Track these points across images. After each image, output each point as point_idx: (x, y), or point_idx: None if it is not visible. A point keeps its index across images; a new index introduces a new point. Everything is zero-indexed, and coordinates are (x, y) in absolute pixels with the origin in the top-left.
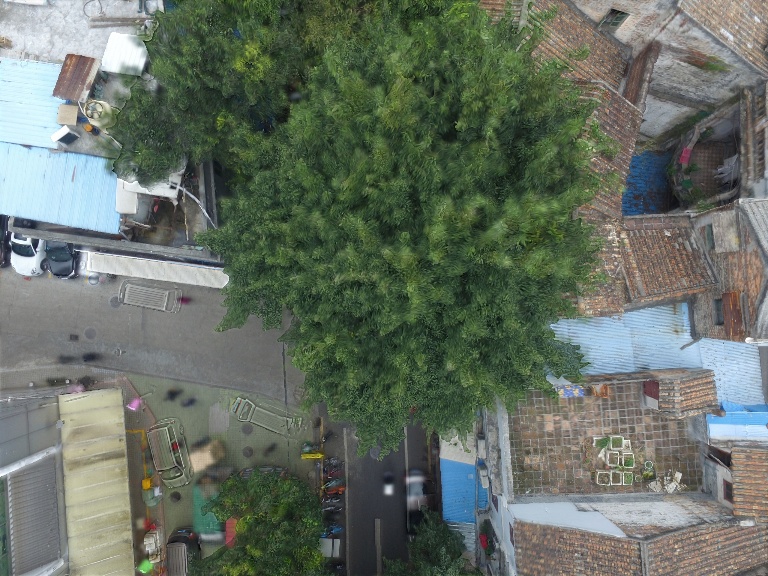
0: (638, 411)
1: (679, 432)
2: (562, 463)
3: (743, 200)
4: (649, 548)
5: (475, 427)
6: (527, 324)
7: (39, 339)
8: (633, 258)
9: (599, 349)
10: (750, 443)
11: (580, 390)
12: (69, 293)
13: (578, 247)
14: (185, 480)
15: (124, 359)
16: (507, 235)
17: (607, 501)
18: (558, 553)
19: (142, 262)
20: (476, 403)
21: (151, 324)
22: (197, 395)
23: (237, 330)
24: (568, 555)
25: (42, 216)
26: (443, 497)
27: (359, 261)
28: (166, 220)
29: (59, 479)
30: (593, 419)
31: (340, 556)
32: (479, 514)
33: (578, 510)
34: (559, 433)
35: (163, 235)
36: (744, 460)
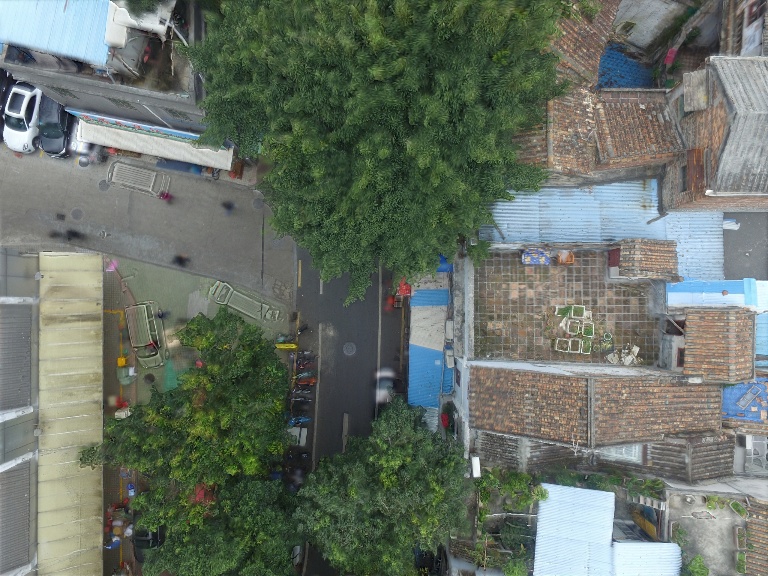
0: (602, 285)
1: (640, 308)
2: (524, 330)
3: (714, 58)
4: (596, 386)
5: (446, 314)
6: (487, 116)
7: (26, 216)
8: (606, 125)
9: (568, 220)
10: (705, 307)
11: (546, 258)
12: (59, 173)
13: (540, 36)
14: (160, 360)
15: (108, 242)
16: (470, 3)
17: (564, 364)
18: (510, 395)
19: (131, 134)
20: (437, 220)
21: (137, 209)
22: (178, 282)
23: (222, 221)
24: (519, 396)
25: (32, 44)
26: (410, 382)
27: (327, 30)
28: (155, 71)
29: (34, 331)
30: (557, 289)
31: (307, 447)
32: (443, 396)
33: (534, 366)
34: (523, 301)
35: (151, 86)
36: (697, 321)
